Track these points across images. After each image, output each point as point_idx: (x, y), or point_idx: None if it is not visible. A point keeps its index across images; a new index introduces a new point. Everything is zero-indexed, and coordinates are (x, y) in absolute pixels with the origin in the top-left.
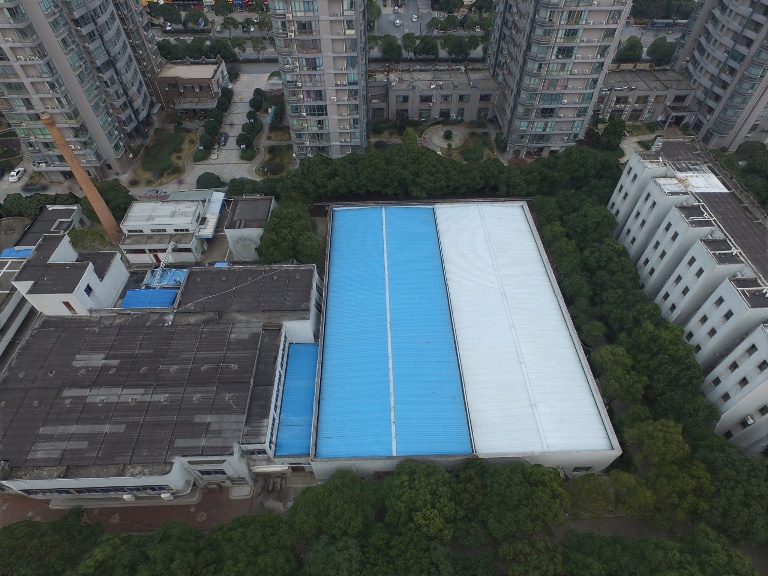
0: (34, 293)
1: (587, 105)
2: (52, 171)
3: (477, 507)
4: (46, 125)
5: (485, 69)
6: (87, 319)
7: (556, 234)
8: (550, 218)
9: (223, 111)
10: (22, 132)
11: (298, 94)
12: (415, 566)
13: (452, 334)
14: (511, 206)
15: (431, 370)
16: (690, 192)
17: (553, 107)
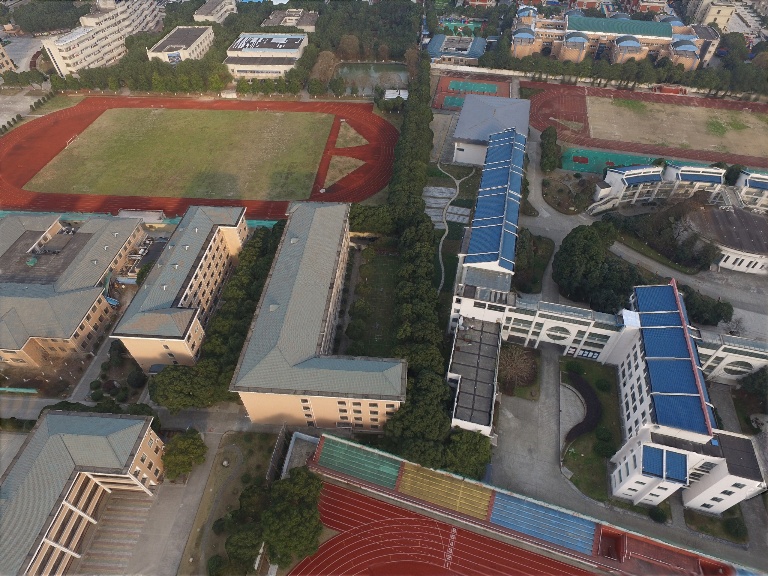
0: None
1: None
2: None
3: (259, 4)
4: None
5: None
6: None
7: None
8: None
9: None
10: None
11: None
12: (246, 3)
13: None
14: None
15: (262, 0)
16: None
17: None
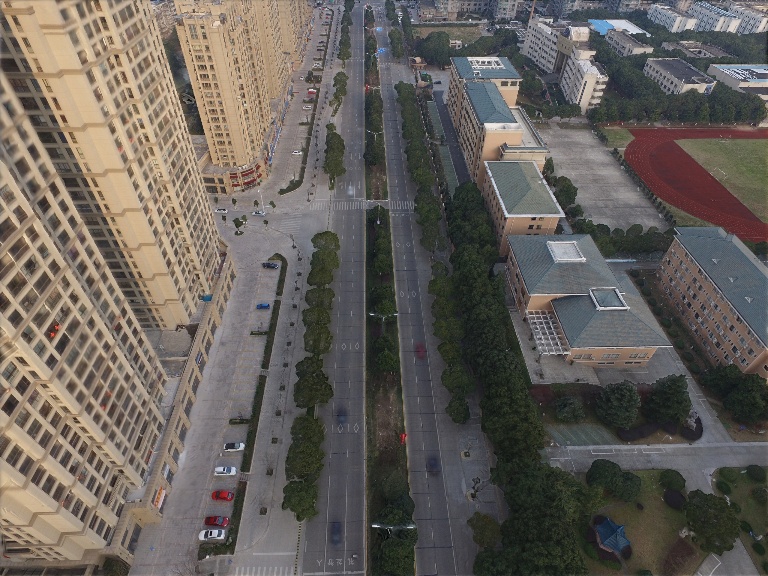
0: (546, 19)
1: None
2: None
3: None
4: None
5: (603, 2)
6: None
7: None
8: None
9: (525, 12)
10: (500, 5)
11: None
12: None
13: None
14: None
15: None
16: (663, 7)
17: (629, 4)
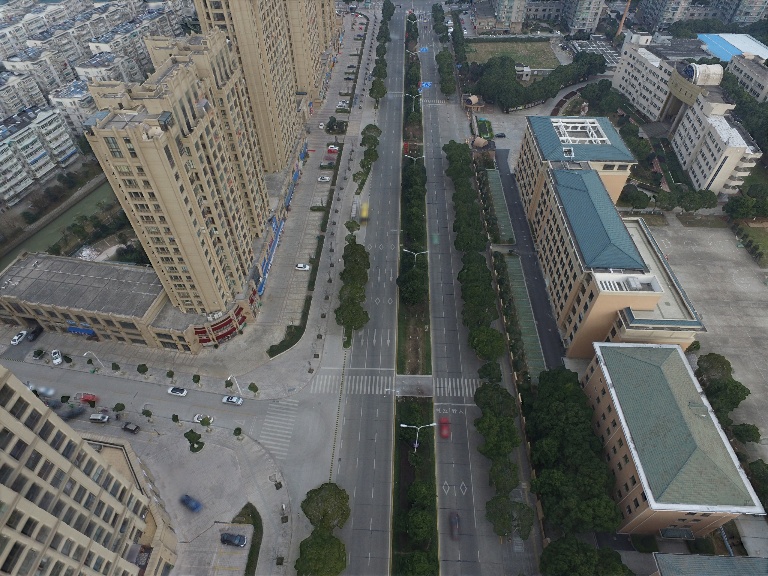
0: (642, 36)
1: (761, 11)
2: (577, 29)
3: (765, 63)
4: (629, 1)
5: (710, 6)
6: (649, 45)
7: (760, 39)
8: (757, 36)
9: None
10: (579, 14)
11: (671, 3)
12: None
13: (742, 51)
14: (742, 35)
15: None
16: None
17: (750, 11)
